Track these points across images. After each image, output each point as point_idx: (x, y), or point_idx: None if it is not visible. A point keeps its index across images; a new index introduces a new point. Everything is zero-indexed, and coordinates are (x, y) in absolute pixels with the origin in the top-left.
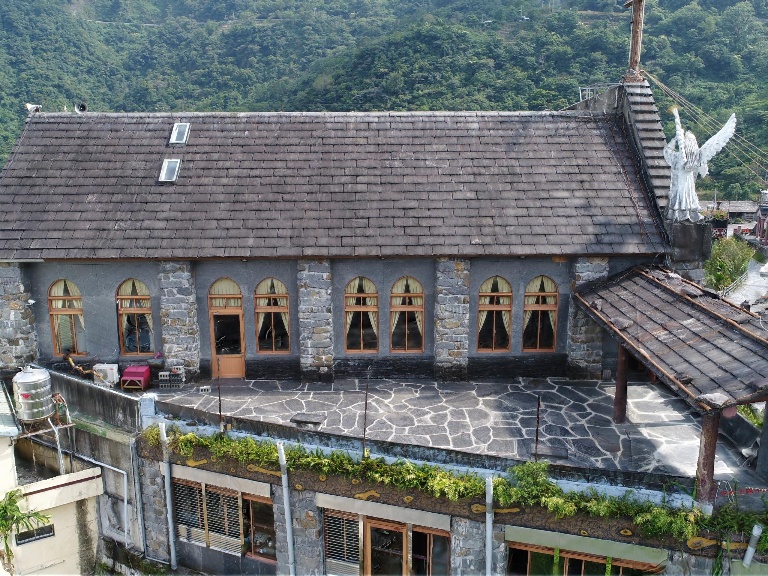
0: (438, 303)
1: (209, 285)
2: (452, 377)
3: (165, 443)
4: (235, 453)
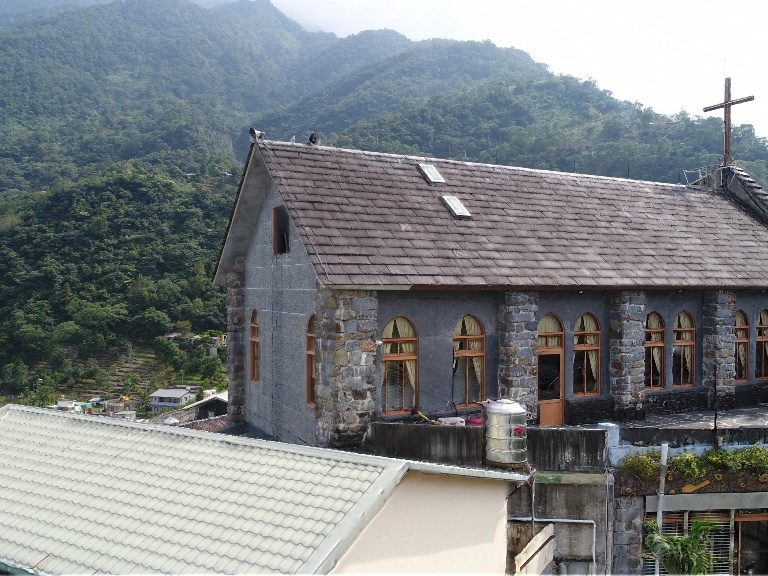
0: (717, 334)
1: (538, 321)
2: (726, 406)
3: (666, 469)
4: (762, 461)
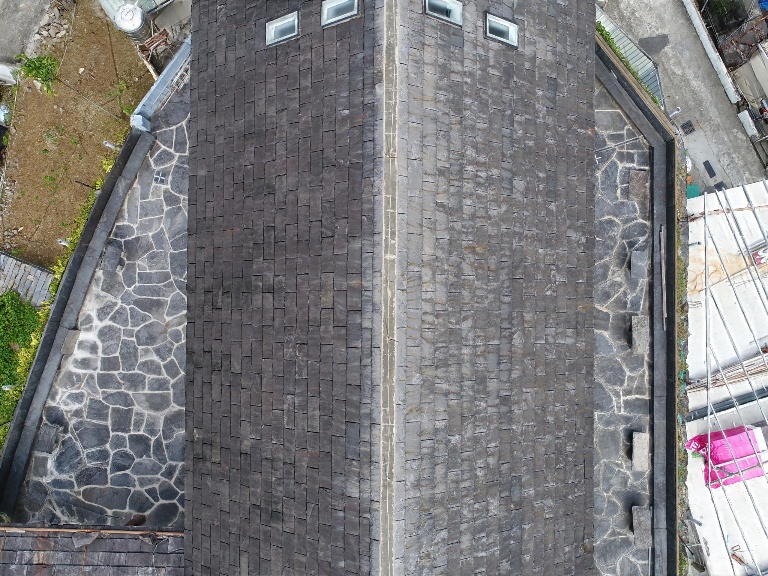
0: None
1: None
2: None
3: None
4: None
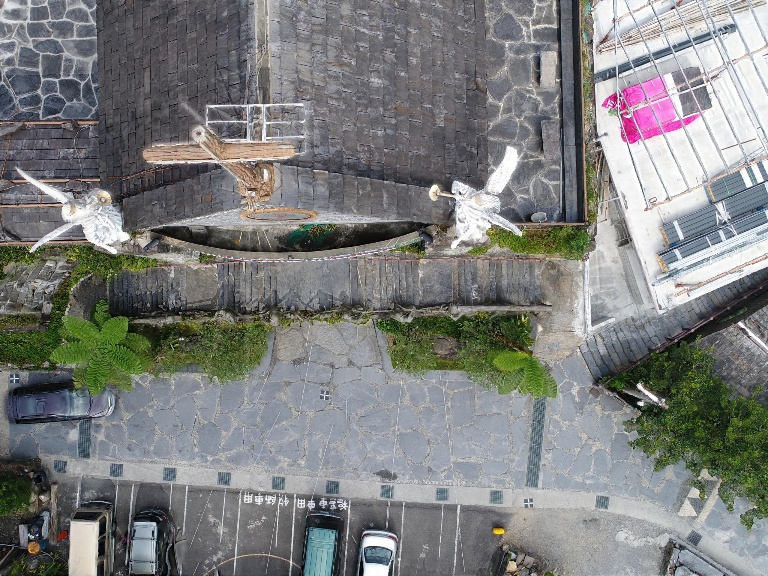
0: None
1: None
2: None
3: None
4: None
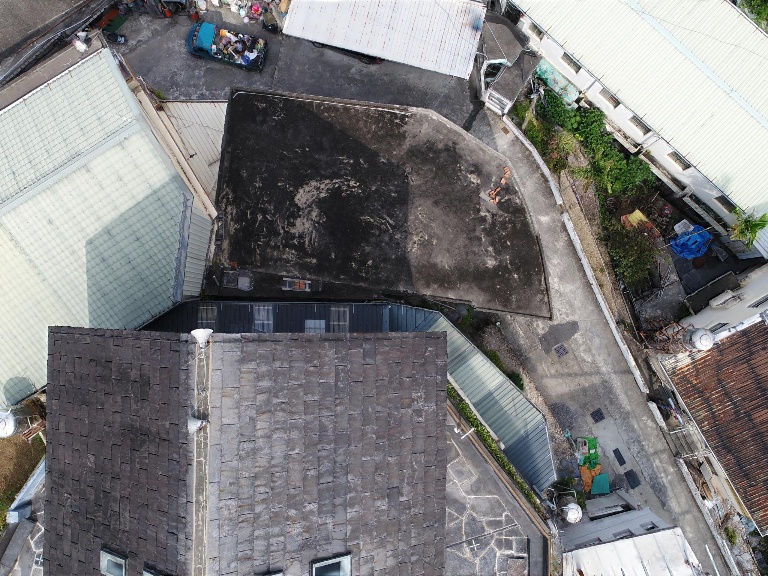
0: None
1: None
2: None
3: None
4: None
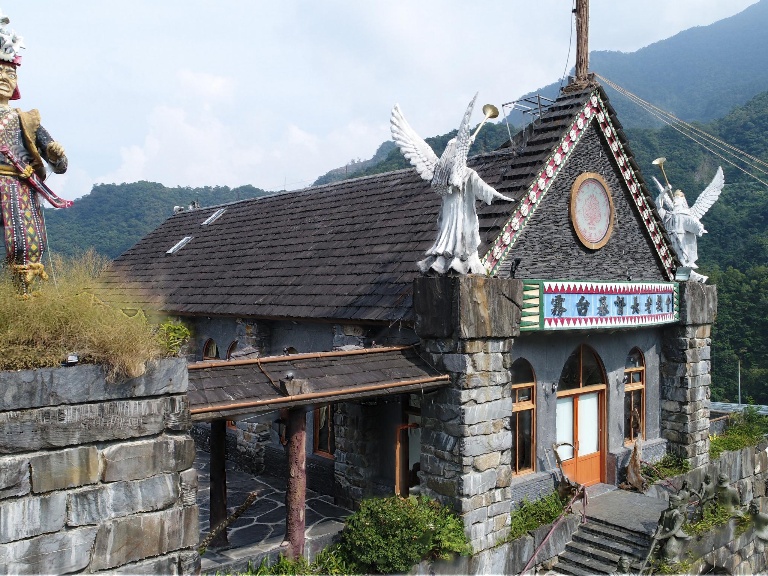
0: None
1: None
2: (246, 466)
3: None
4: None
